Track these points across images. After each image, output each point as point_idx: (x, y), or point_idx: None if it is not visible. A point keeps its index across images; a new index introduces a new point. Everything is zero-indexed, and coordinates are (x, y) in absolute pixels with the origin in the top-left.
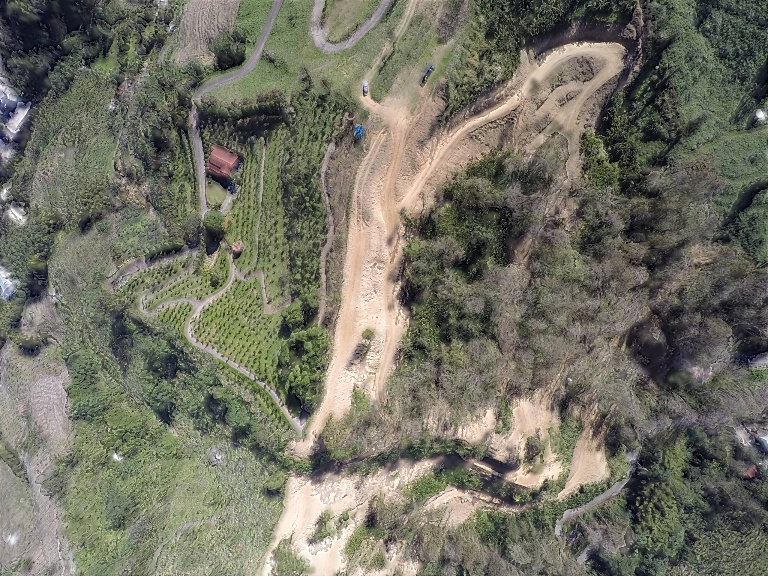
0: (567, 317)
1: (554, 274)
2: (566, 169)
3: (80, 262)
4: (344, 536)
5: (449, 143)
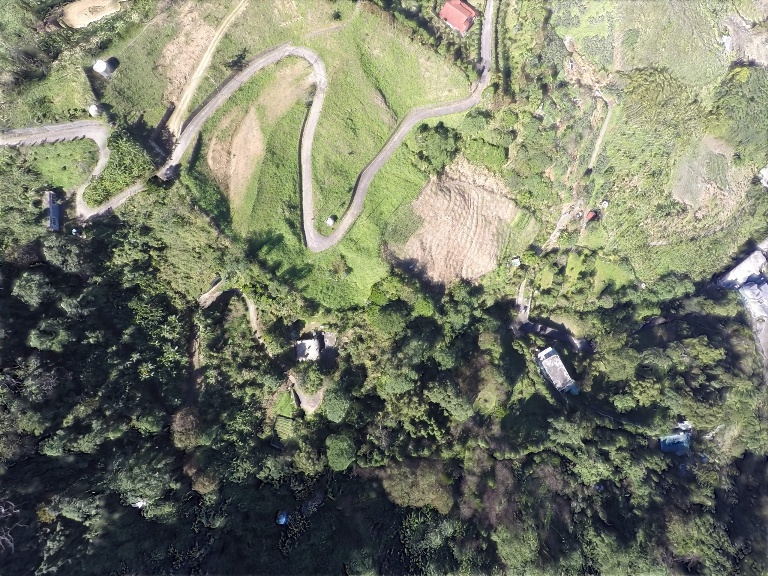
0: None
1: None
2: None
3: (664, 0)
4: None
5: None
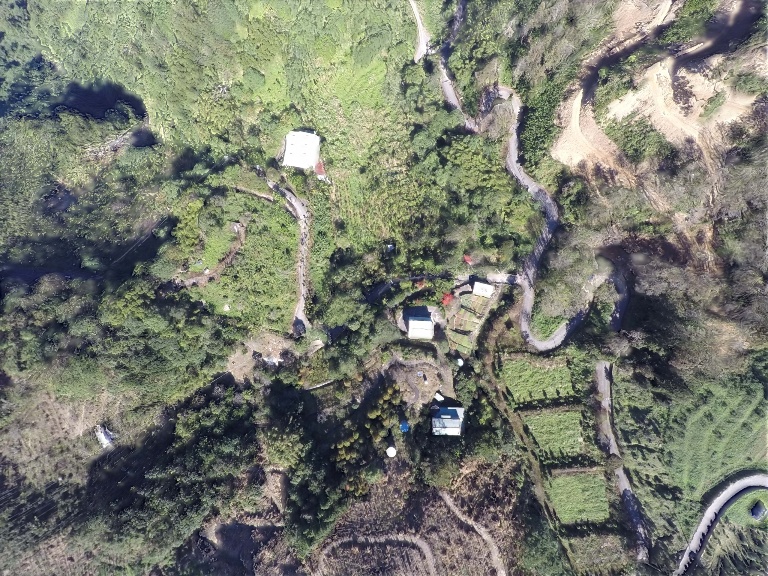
0: None
1: None
2: None
3: None
4: None
5: None
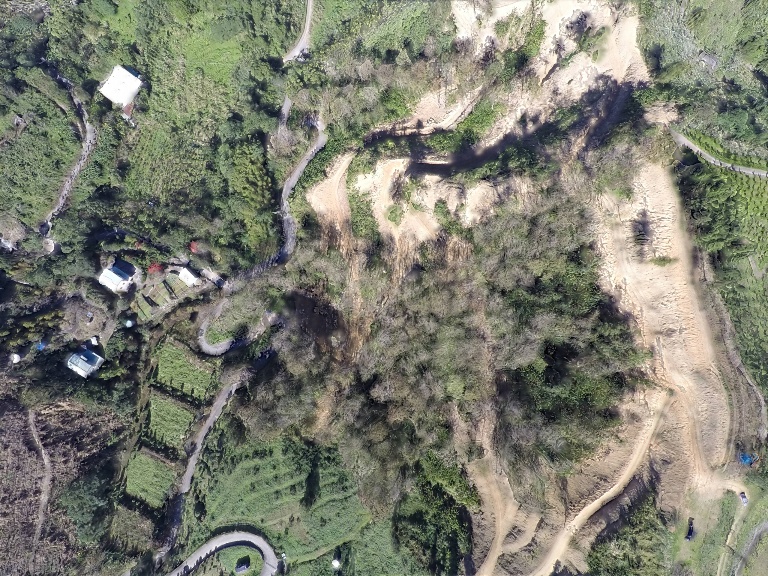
0: (451, 338)
1: (482, 374)
2: (485, 469)
3: None
4: (549, 41)
5: (635, 469)
